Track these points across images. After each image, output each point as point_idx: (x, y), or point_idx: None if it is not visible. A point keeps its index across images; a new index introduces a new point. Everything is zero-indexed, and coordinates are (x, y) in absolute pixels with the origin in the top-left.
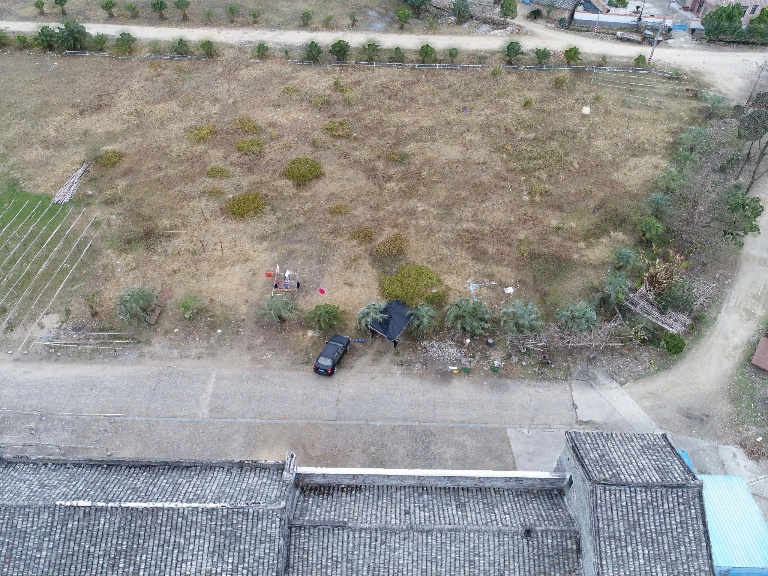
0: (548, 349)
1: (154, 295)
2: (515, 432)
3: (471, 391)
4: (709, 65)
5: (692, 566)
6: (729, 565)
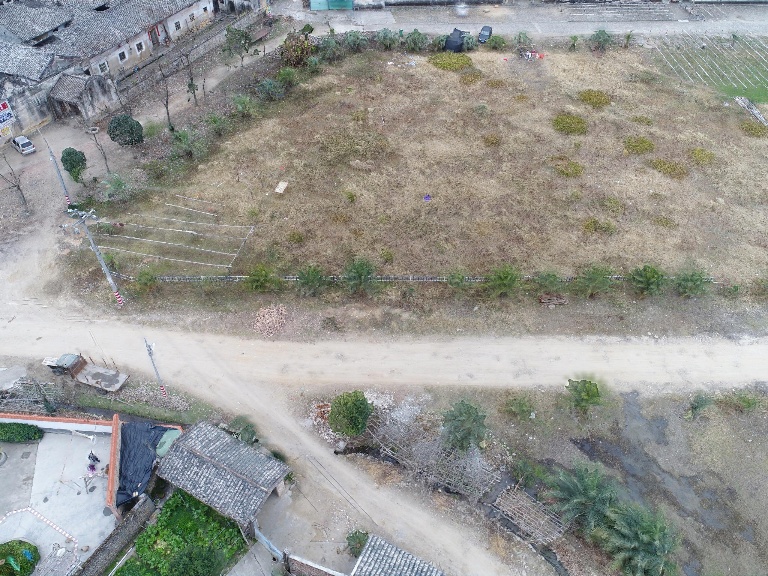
0: (372, 42)
1: (595, 35)
2: (393, 22)
3: None
4: (11, 311)
5: None
6: None
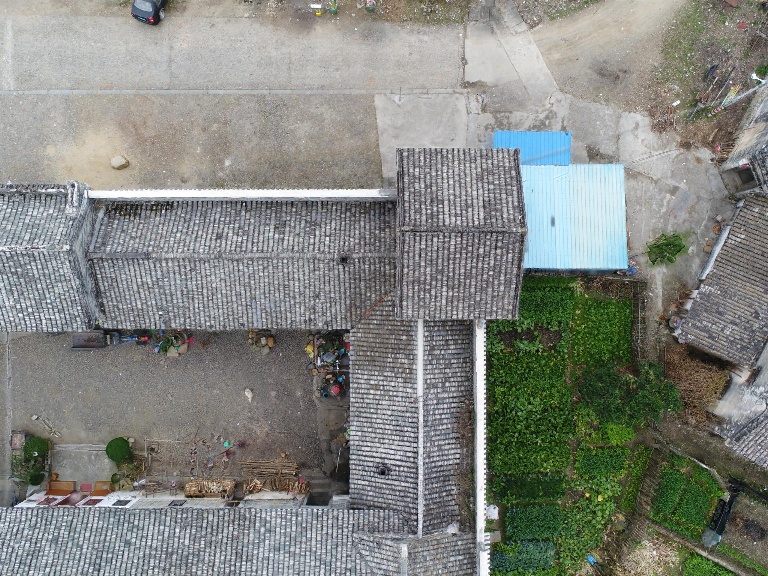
0: None
1: None
2: (384, 100)
3: (337, 42)
4: None
5: (495, 306)
6: (566, 267)
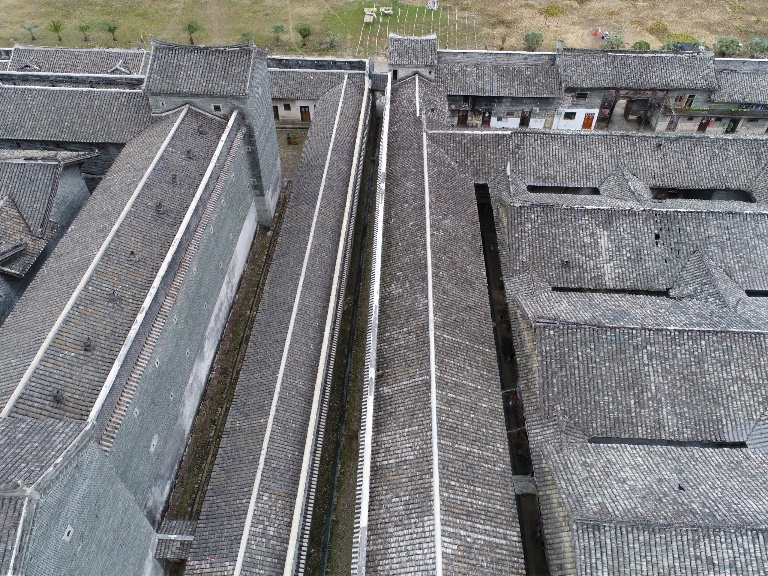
0: None
1: None
2: None
3: None
4: None
5: None
6: None
